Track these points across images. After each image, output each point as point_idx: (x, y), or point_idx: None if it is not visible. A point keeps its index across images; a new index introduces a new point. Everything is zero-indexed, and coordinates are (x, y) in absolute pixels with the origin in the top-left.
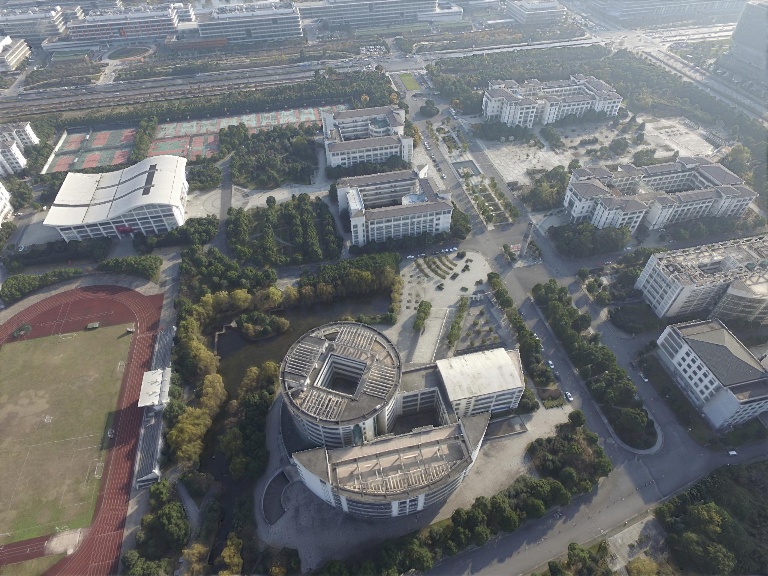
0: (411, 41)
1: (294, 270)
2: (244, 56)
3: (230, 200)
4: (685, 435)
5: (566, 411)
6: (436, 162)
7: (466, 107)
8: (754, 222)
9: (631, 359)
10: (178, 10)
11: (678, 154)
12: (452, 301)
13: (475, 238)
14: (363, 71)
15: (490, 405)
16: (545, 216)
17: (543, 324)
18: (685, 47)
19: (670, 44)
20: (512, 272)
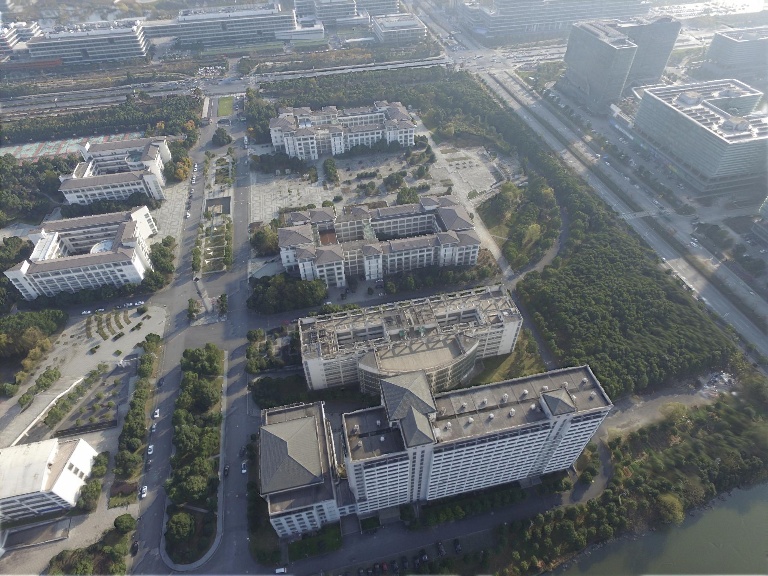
0: (254, 61)
1: None
2: (74, 78)
3: None
4: (245, 545)
5: (128, 512)
6: (191, 199)
7: (258, 136)
8: (478, 272)
9: (246, 443)
10: (18, 29)
11: (451, 190)
12: (95, 368)
13: (172, 290)
14: None
15: (27, 507)
16: (265, 263)
17: (176, 397)
18: (534, 68)
19: (521, 65)
20: (185, 332)
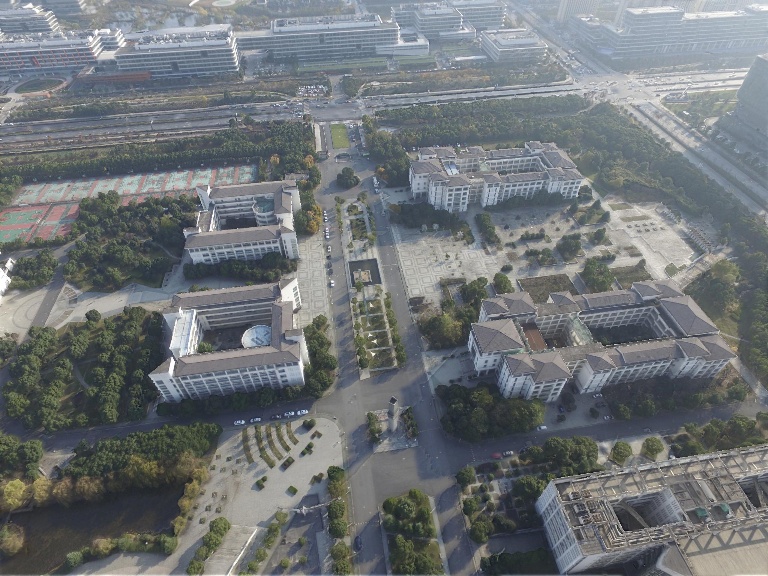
0: (359, 81)
1: (77, 435)
2: (164, 94)
3: (51, 307)
4: None
5: None
6: (330, 259)
7: (391, 178)
8: (729, 394)
9: None
10: (103, 37)
11: (644, 263)
12: (268, 513)
13: (338, 393)
14: (288, 121)
15: None
16: (443, 359)
17: (384, 572)
18: (683, 100)
19: (666, 95)
20: (369, 461)
